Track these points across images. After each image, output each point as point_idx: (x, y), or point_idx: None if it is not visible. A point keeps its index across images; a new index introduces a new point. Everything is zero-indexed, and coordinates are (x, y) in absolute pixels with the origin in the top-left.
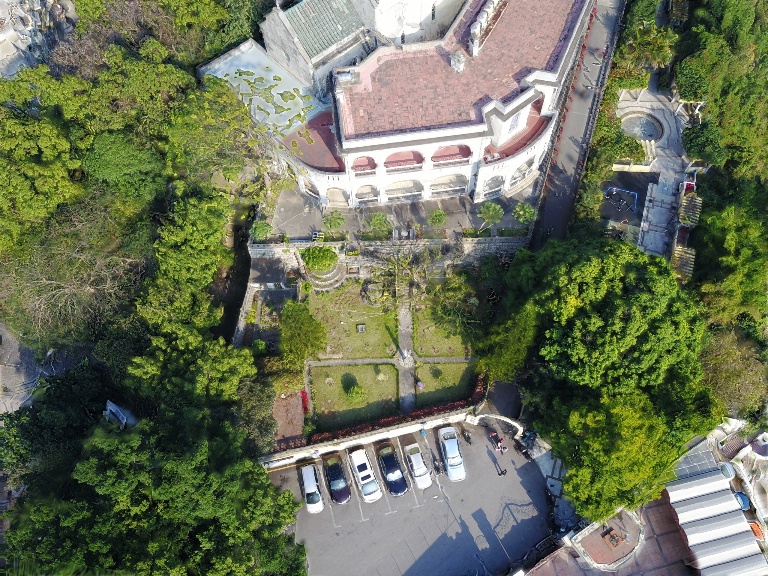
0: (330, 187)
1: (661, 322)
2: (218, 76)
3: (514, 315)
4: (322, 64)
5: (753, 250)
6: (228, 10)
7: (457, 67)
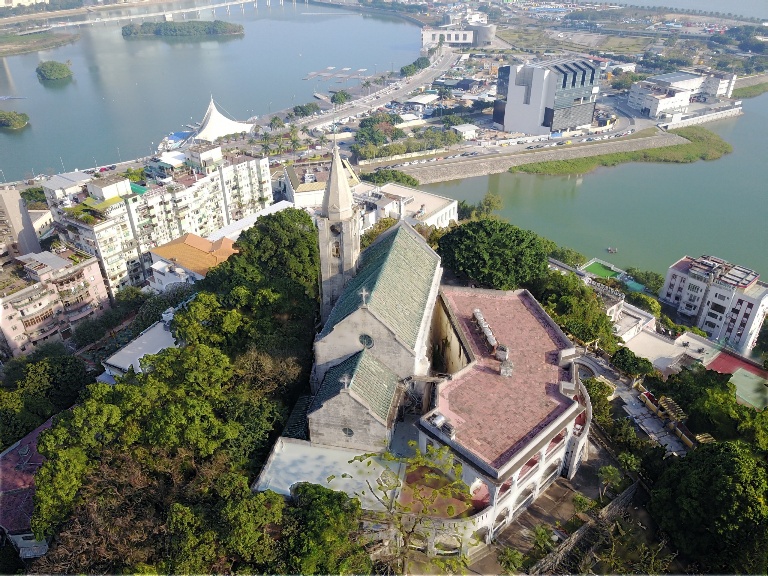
0: (475, 531)
1: None
2: (276, 487)
3: (758, 535)
4: (392, 422)
5: (746, 411)
6: (238, 422)
7: (509, 373)
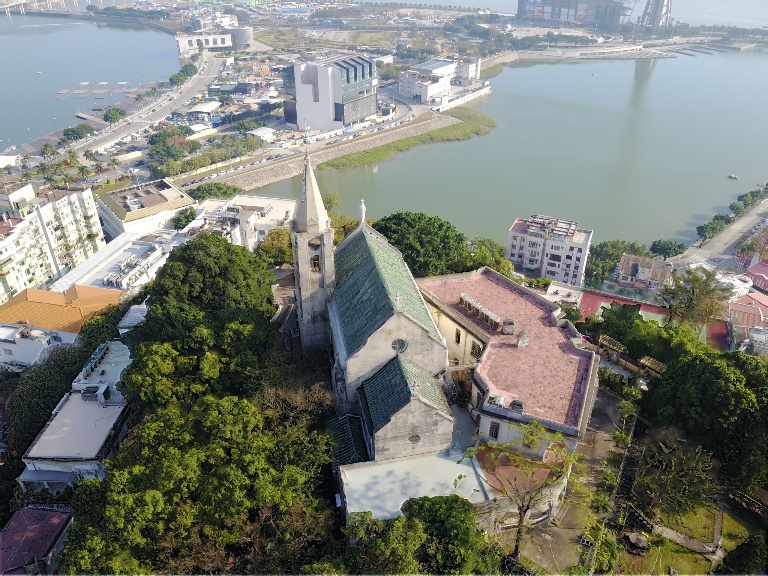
0: None
1: (763, 366)
2: None
3: None
4: (452, 417)
5: (670, 329)
6: (291, 465)
7: (526, 343)
